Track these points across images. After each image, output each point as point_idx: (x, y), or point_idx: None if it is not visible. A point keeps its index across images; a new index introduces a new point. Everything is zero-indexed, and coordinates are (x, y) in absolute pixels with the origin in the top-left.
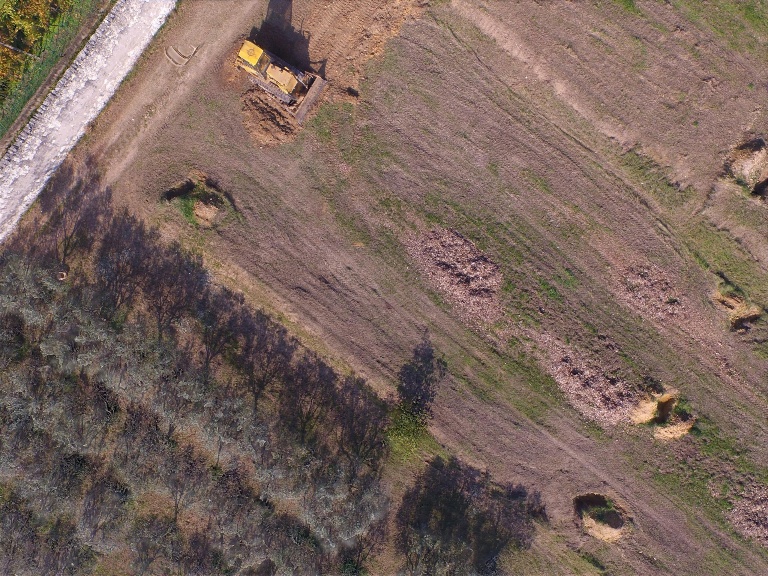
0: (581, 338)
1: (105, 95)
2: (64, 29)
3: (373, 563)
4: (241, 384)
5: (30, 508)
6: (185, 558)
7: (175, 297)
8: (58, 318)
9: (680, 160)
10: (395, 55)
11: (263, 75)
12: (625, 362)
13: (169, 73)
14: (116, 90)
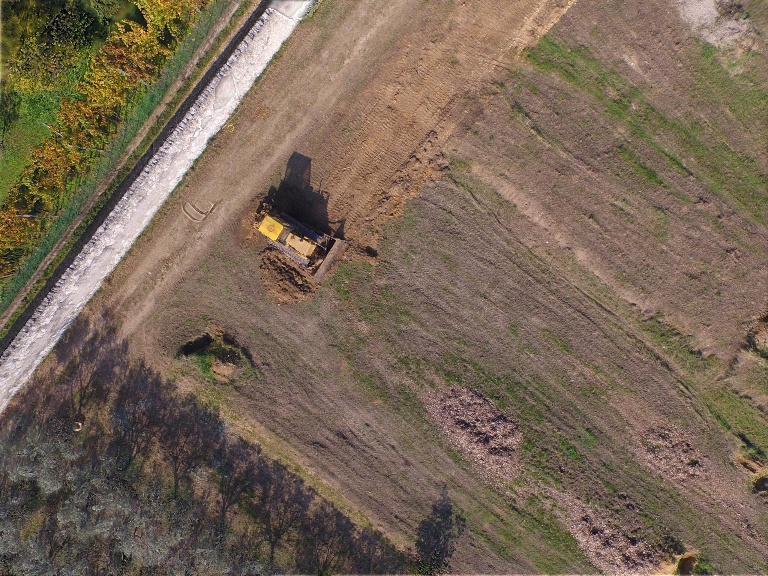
0: (601, 497)
1: (122, 251)
2: (81, 188)
3: None
4: (257, 533)
5: None
6: None
7: (191, 447)
8: (76, 488)
9: (703, 330)
10: (414, 216)
11: (282, 243)
12: (645, 522)
13: (186, 228)
14: (133, 244)
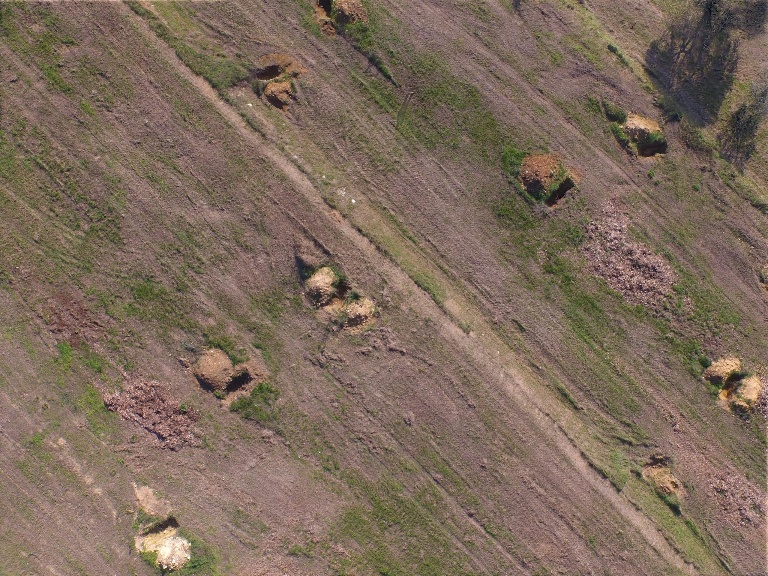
0: None
1: None
2: None
3: None
4: None
5: None
6: None
7: None
8: None
9: None
10: None
11: None
12: (764, 436)
13: None
14: None
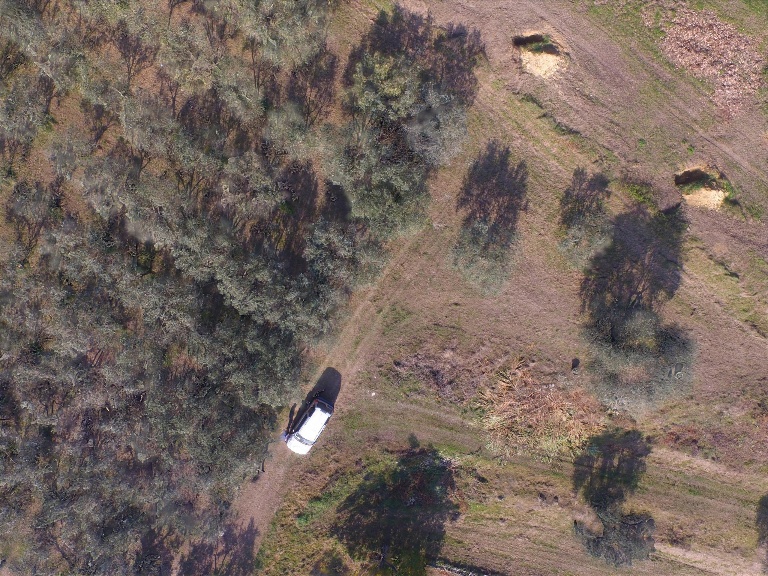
0: None
1: None
2: None
3: (321, 127)
4: None
5: None
6: (138, 126)
7: None
8: None
9: None
10: None
11: None
12: None
13: None
14: None
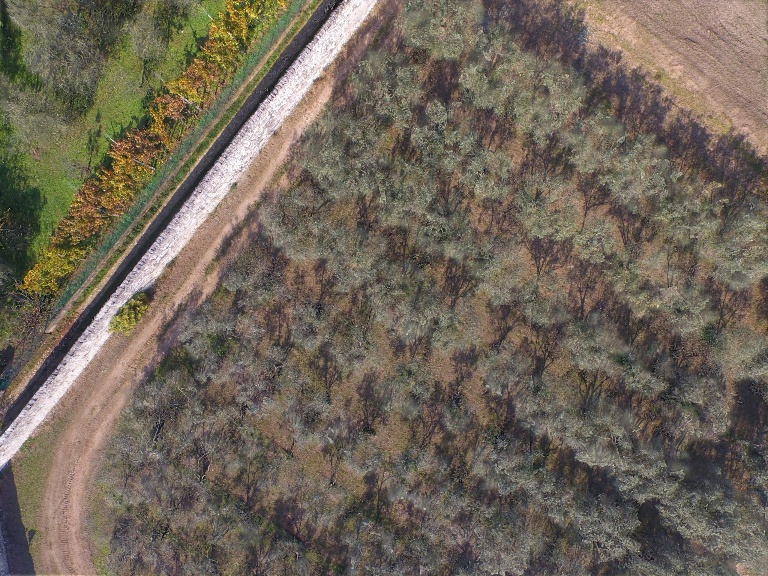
0: None
1: None
2: None
3: (733, 330)
4: (612, 146)
5: (391, 276)
6: (544, 326)
7: (551, 56)
8: (486, 44)
9: None
10: None
11: None
12: None
13: None
14: None
